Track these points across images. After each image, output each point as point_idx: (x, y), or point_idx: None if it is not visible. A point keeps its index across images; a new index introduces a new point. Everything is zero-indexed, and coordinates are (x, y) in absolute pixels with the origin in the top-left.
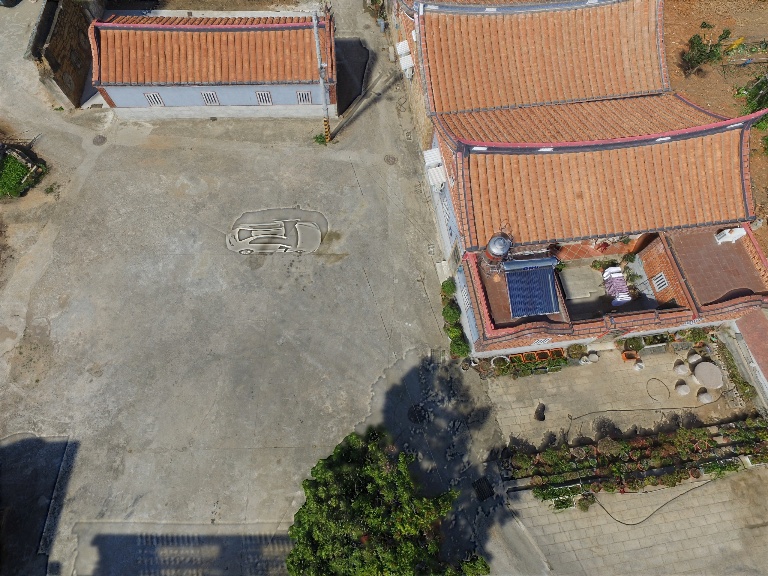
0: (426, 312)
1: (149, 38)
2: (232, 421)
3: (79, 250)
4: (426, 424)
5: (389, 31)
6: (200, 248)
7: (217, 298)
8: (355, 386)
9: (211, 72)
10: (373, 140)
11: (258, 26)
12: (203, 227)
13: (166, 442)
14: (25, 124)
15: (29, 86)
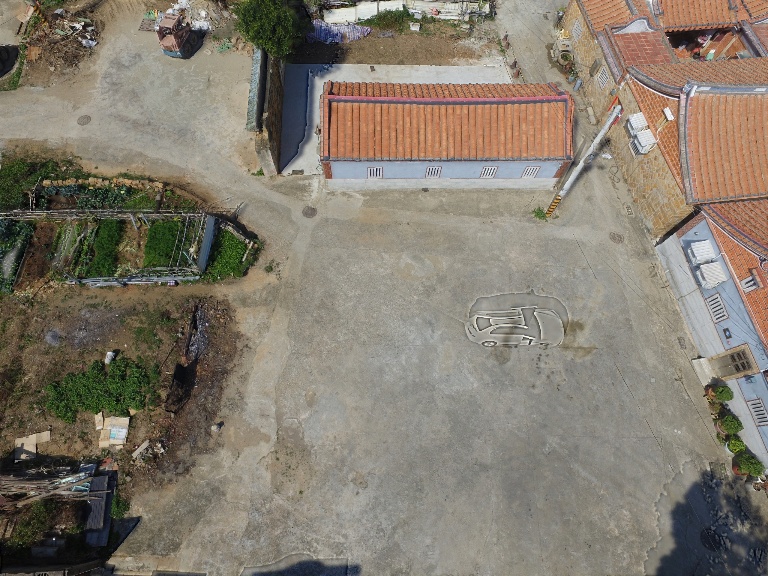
0: (693, 417)
1: (380, 111)
2: (516, 544)
3: (315, 339)
4: (724, 552)
5: (583, 90)
6: (440, 339)
7: (470, 398)
8: (637, 504)
9: (444, 147)
10: (593, 215)
11: (495, 99)
12: (438, 314)
13: (451, 568)
14: (224, 190)
15: (221, 148)
